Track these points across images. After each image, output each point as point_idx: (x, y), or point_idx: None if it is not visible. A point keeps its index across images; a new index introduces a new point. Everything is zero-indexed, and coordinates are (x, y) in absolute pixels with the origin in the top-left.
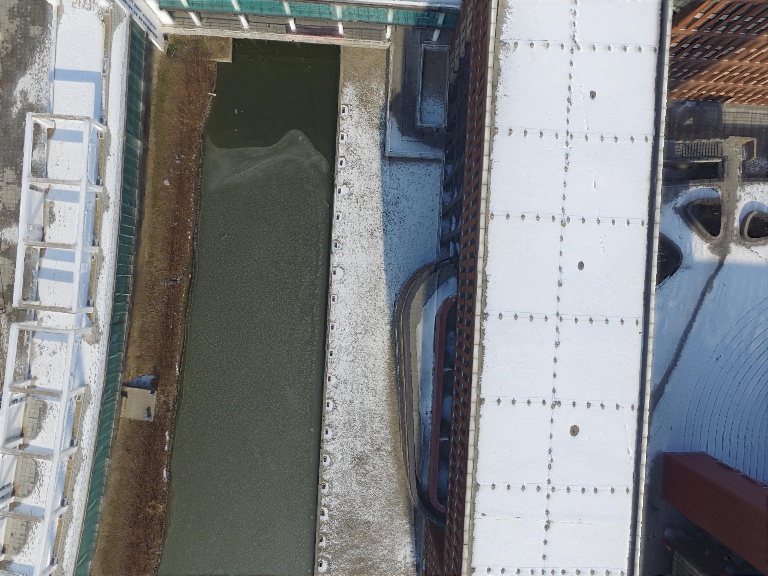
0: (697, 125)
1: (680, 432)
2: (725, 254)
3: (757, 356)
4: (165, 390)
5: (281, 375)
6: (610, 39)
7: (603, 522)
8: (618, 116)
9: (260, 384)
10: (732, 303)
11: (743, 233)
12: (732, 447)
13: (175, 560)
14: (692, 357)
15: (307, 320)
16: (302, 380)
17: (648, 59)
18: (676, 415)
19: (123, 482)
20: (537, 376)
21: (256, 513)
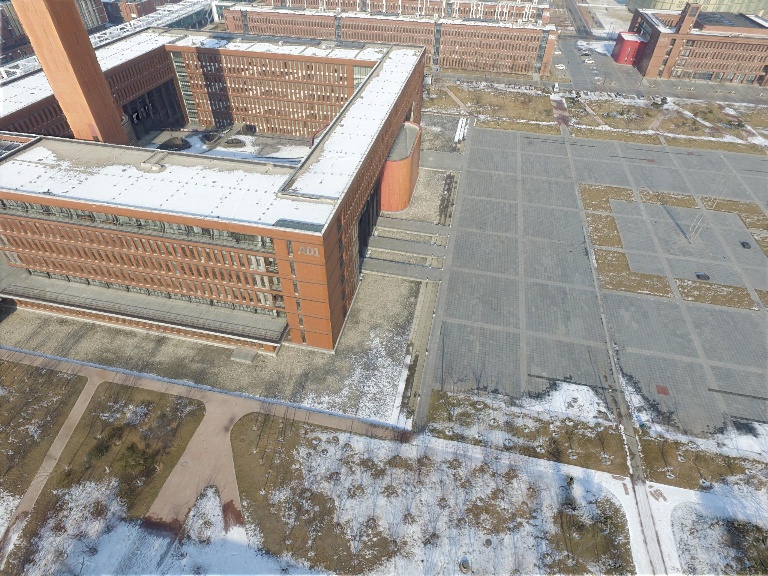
0: None
1: None
2: None
3: None
4: None
5: None
6: None
7: None
8: None
9: None
10: None
11: None
12: None
13: None
14: None
15: None
16: None
17: None
18: None
19: None
20: (35, 84)
21: None
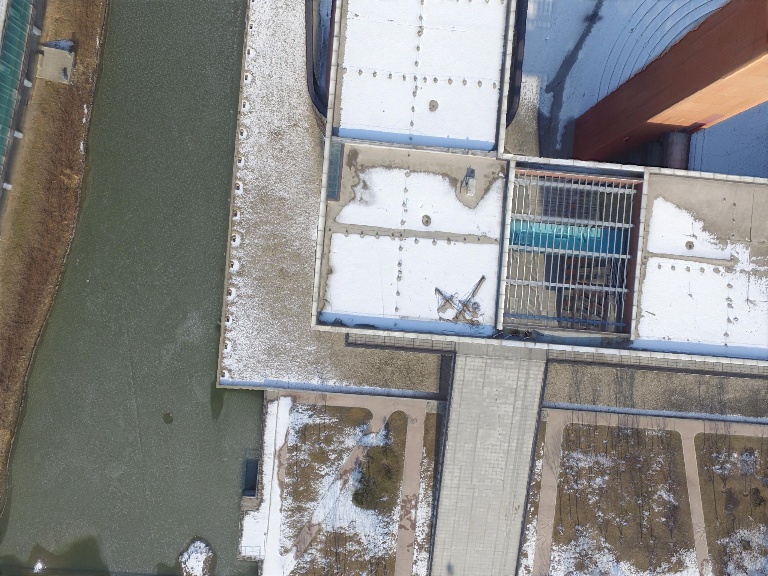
0: None
1: (593, 100)
2: None
3: (674, 35)
4: (85, 61)
5: (202, 54)
6: None
7: (477, 31)
8: None
9: (181, 62)
10: None
11: None
12: None
13: (90, 235)
14: (607, 25)
15: (230, 0)
16: (223, 60)
17: None
18: (589, 82)
19: (38, 144)
20: None
21: (173, 192)
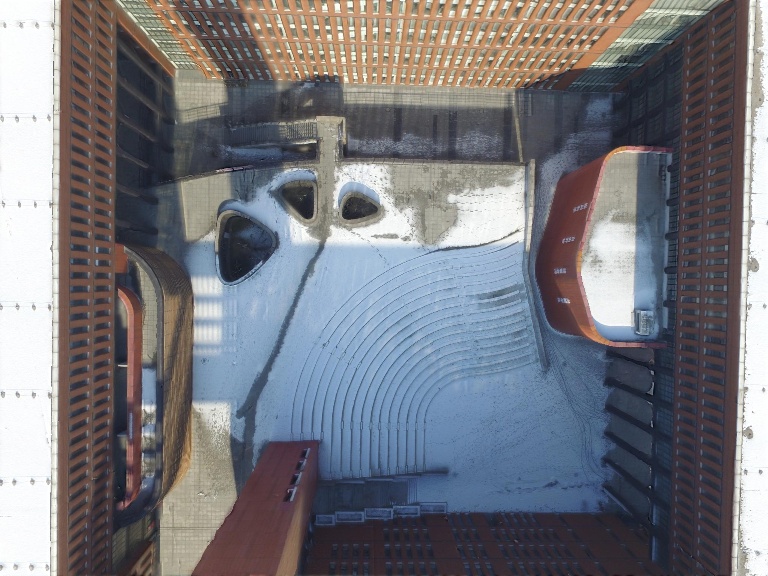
0: (317, 107)
1: (287, 421)
2: (325, 237)
3: (373, 341)
4: None
5: None
6: (5, 16)
7: (24, 515)
8: (18, 95)
9: None
10: (335, 287)
11: (338, 215)
12: (355, 434)
13: None
14: (296, 343)
15: None
16: None
17: (47, 35)
18: (281, 403)
19: None
20: None
21: None
